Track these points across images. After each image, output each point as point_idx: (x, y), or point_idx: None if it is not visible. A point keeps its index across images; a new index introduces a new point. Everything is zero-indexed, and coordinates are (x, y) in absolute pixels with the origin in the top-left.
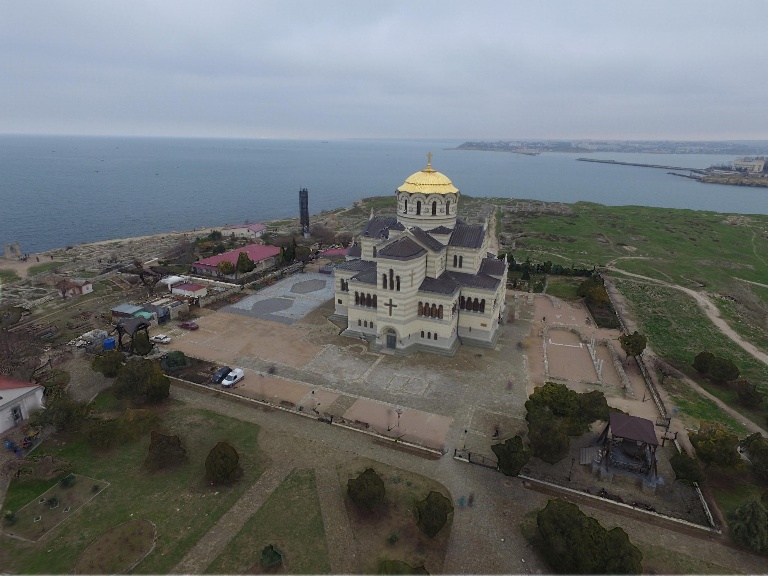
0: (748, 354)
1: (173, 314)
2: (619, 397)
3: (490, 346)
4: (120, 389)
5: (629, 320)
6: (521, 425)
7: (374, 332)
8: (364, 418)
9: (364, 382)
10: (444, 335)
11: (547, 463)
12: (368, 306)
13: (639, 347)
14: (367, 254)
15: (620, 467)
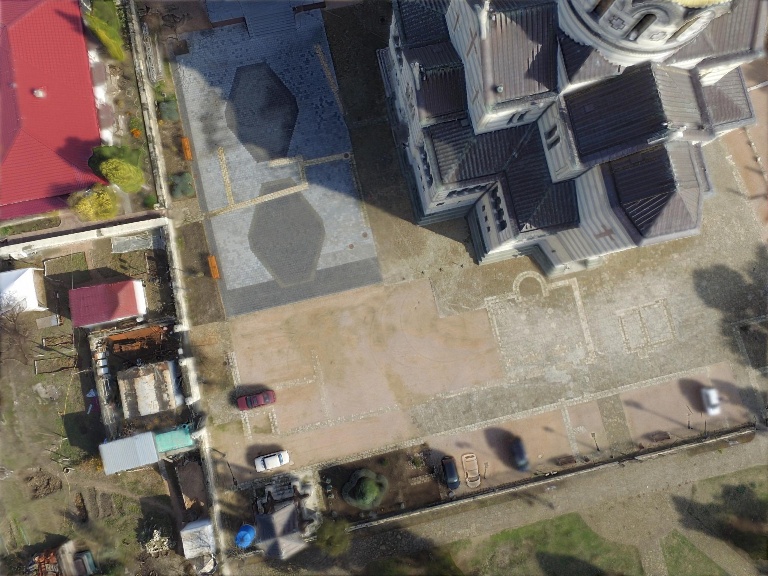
0: None
1: (195, 394)
2: None
3: None
4: None
5: None
6: None
7: (536, 242)
8: (654, 425)
9: (599, 357)
10: None
11: None
12: None
13: None
14: (494, 125)
15: None
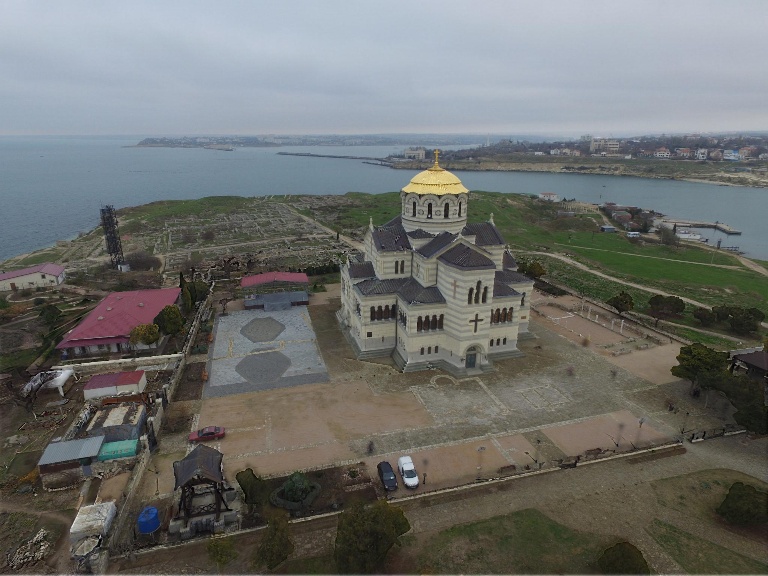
0: (645, 291)
1: (155, 428)
2: (656, 346)
3: (532, 336)
4: (361, 568)
5: (560, 285)
6: (664, 393)
7: (440, 356)
8: (582, 445)
9: (512, 411)
10: (513, 337)
11: (726, 414)
12: (433, 329)
13: (632, 303)
14: (388, 271)
15: (765, 394)
